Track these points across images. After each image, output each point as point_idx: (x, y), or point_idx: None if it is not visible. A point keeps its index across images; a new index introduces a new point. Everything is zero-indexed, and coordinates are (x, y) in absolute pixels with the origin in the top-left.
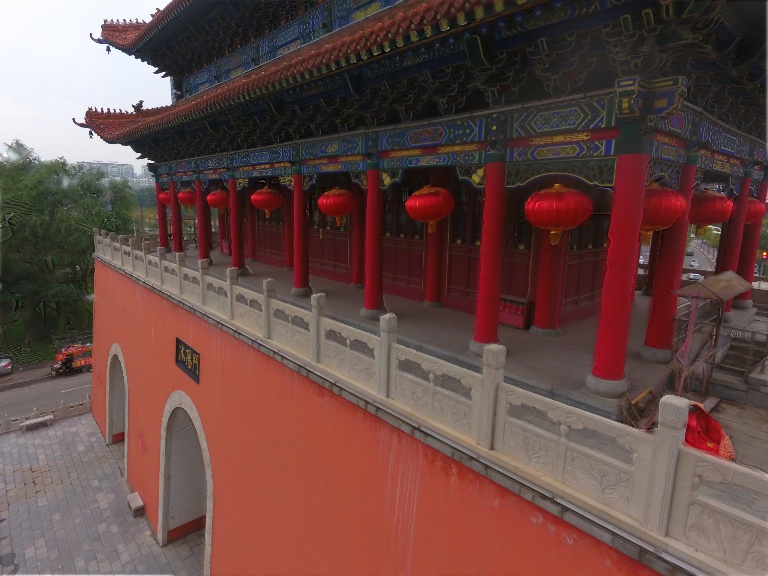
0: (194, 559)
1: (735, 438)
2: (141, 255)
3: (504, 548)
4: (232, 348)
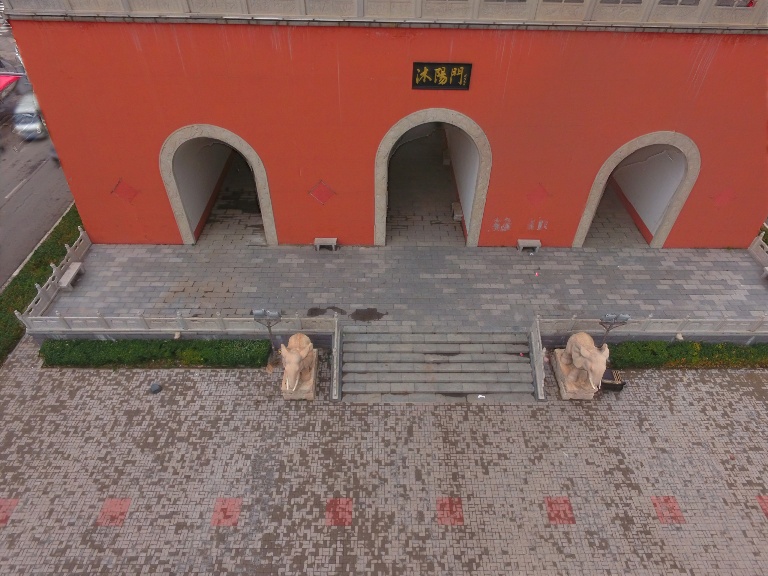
0: (412, 237)
1: None
2: None
3: (752, 59)
4: (539, 41)
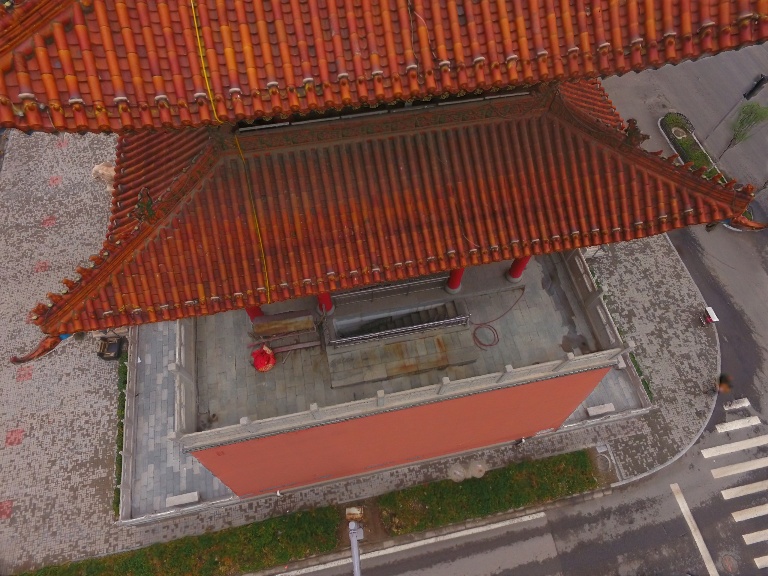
0: None
1: (284, 364)
2: None
3: None
4: None
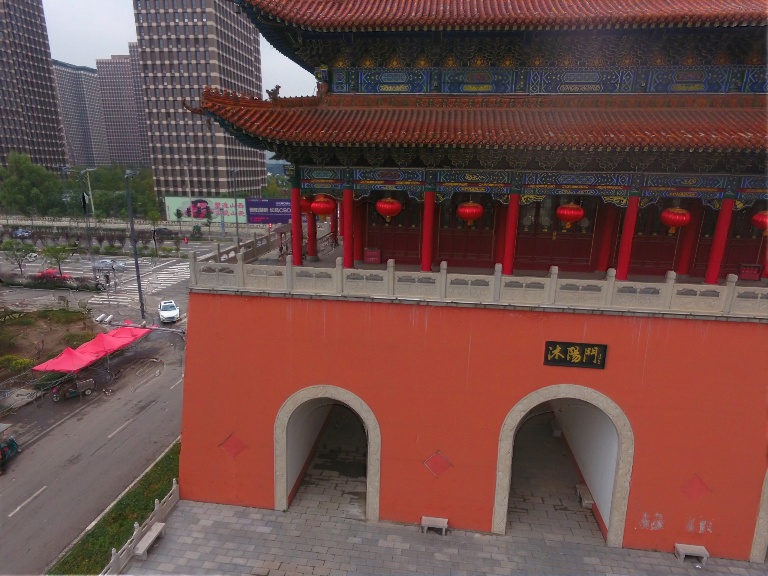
0: (536, 525)
1: None
2: (427, 276)
3: None
4: (677, 328)
